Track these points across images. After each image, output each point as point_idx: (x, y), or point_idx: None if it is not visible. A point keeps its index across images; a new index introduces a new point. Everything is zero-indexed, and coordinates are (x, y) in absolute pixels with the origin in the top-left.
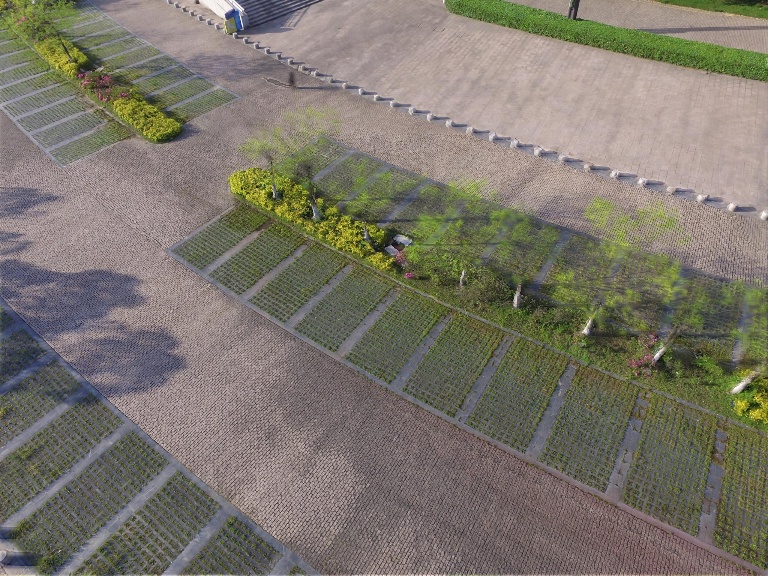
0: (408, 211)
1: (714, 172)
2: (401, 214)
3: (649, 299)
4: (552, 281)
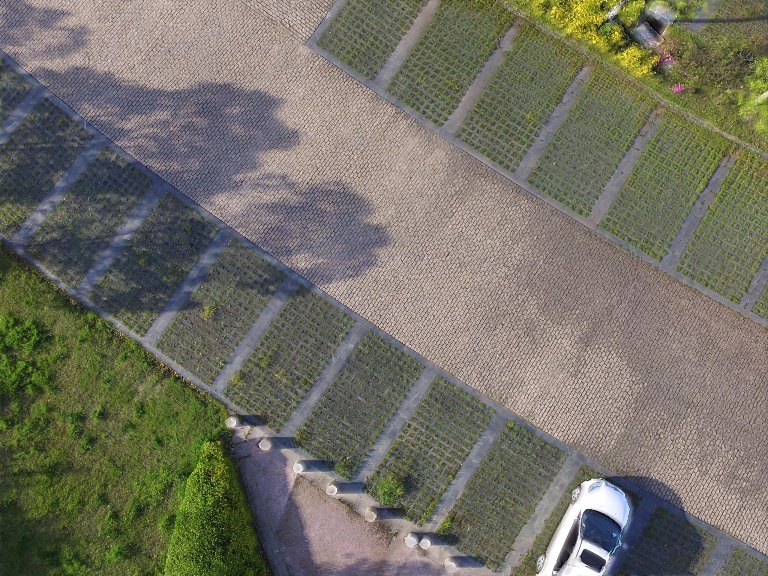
0: None
1: None
2: None
3: None
4: None
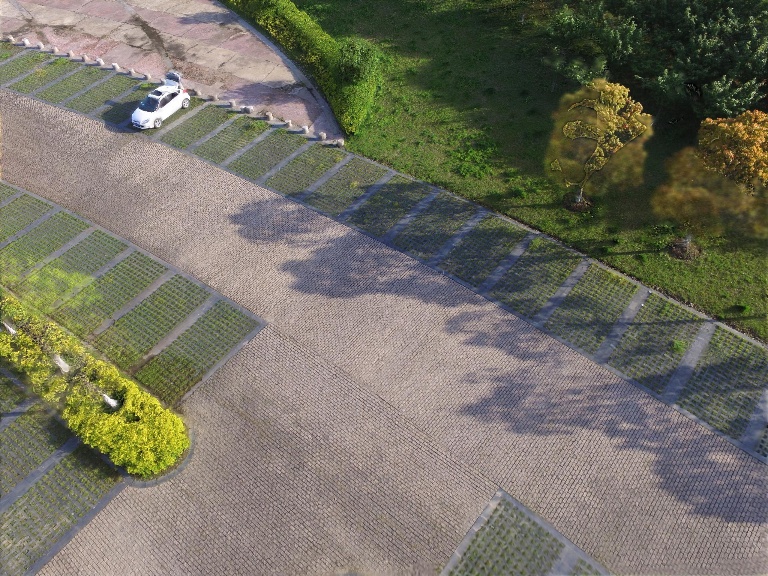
0: None
1: None
2: None
3: None
4: None
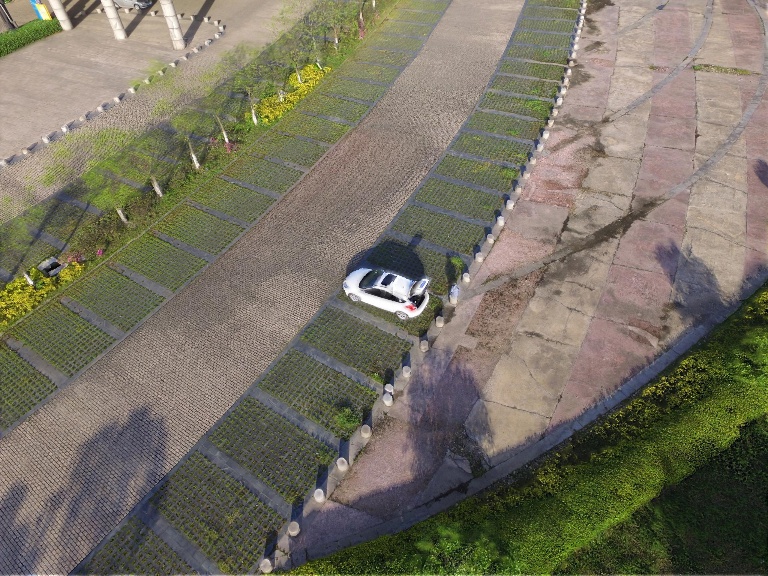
0: (6, 262)
1: (76, 101)
2: (7, 266)
3: (180, 142)
4: (145, 179)
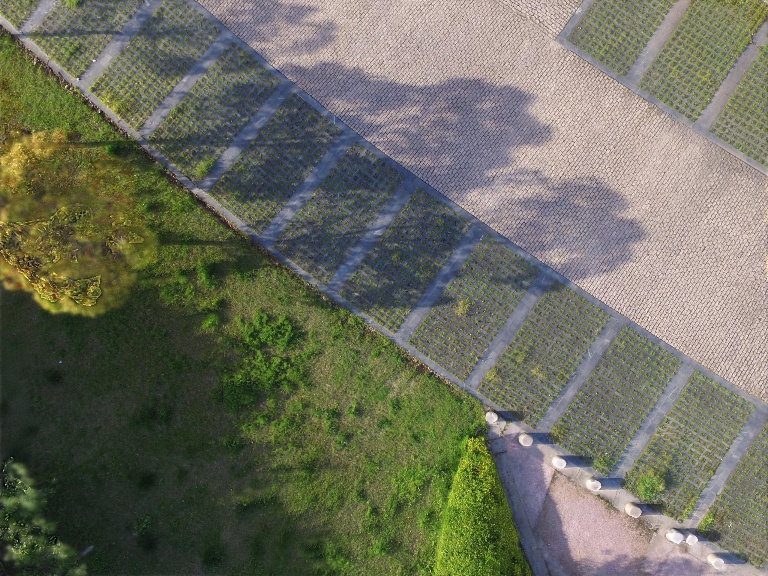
0: None
1: None
2: None
3: None
4: None
